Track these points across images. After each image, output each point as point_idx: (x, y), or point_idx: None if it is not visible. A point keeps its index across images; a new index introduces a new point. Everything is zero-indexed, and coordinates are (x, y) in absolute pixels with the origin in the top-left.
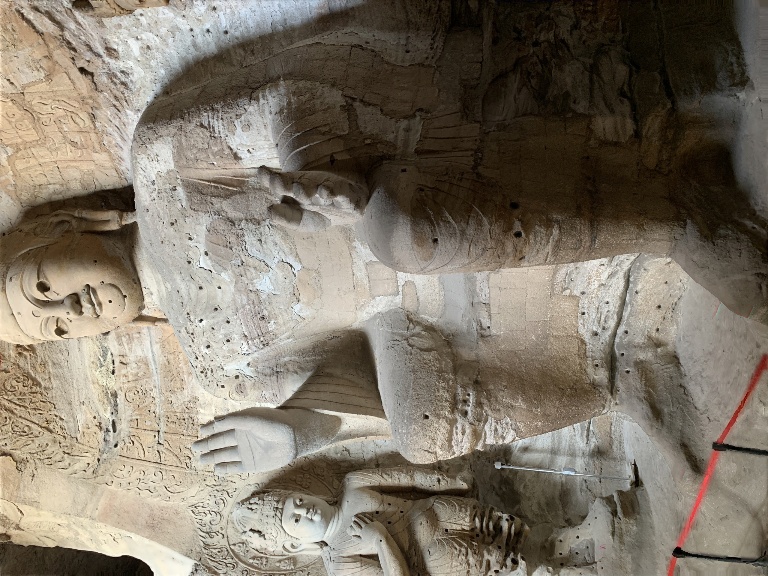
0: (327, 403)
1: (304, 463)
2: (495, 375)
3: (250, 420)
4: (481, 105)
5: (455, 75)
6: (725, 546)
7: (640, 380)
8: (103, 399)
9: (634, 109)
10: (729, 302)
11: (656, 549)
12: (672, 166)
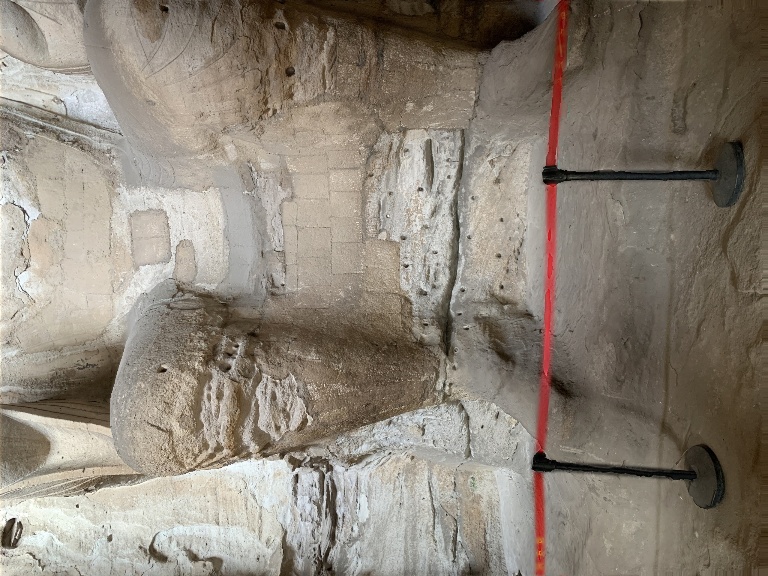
0: (30, 408)
1: None
2: (282, 329)
3: None
4: None
5: None
6: (636, 534)
7: (483, 332)
8: None
9: None
10: (543, 64)
11: None
12: (476, 38)
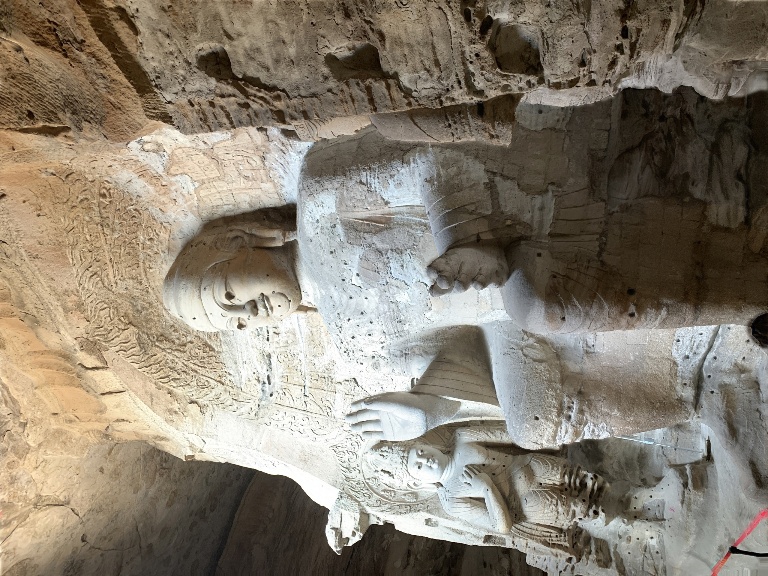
0: (451, 390)
1: None
2: (596, 387)
3: (392, 406)
4: (607, 181)
5: (584, 143)
6: None
7: (722, 401)
8: (260, 360)
9: (747, 195)
10: None
11: (718, 519)
12: None
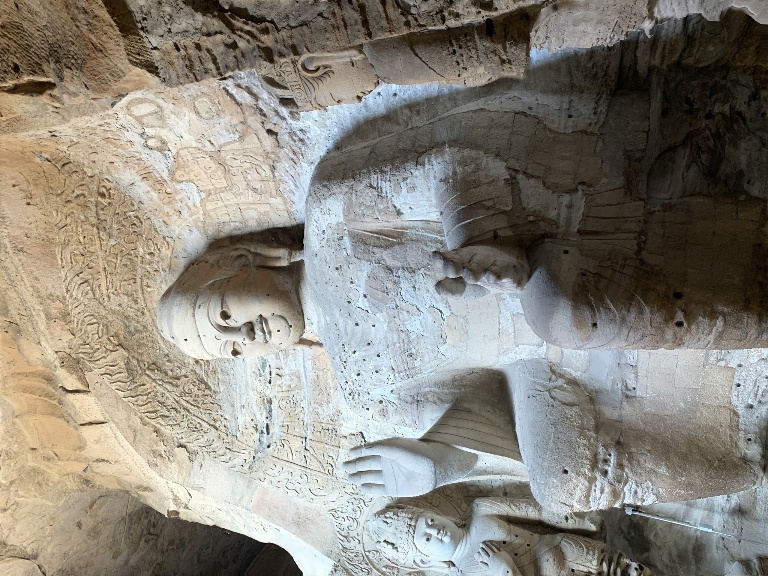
0: (466, 440)
1: None
2: (638, 438)
3: (396, 451)
4: (646, 181)
5: (619, 145)
6: None
7: None
8: (260, 405)
9: None
10: None
11: None
12: None
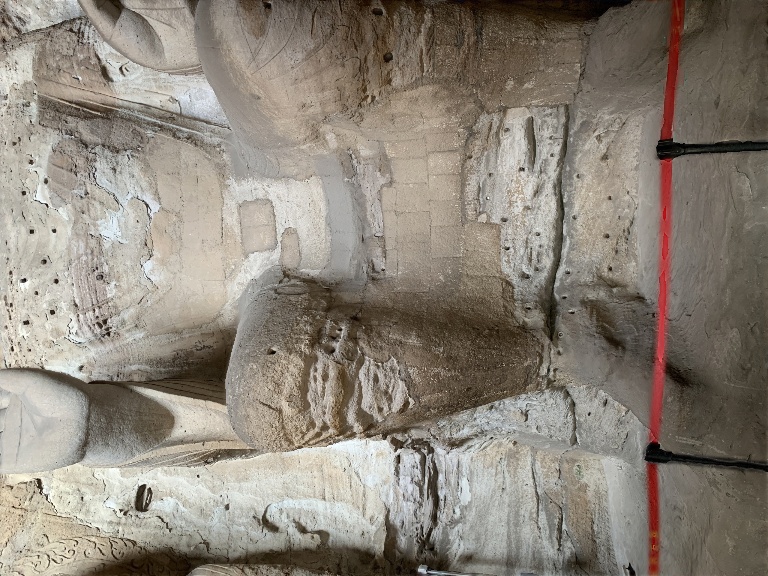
0: (156, 386)
1: (137, 556)
2: (383, 313)
3: (27, 375)
4: None
5: None
6: (764, 534)
7: (589, 316)
8: None
9: None
10: (657, 29)
11: None
12: (581, 7)
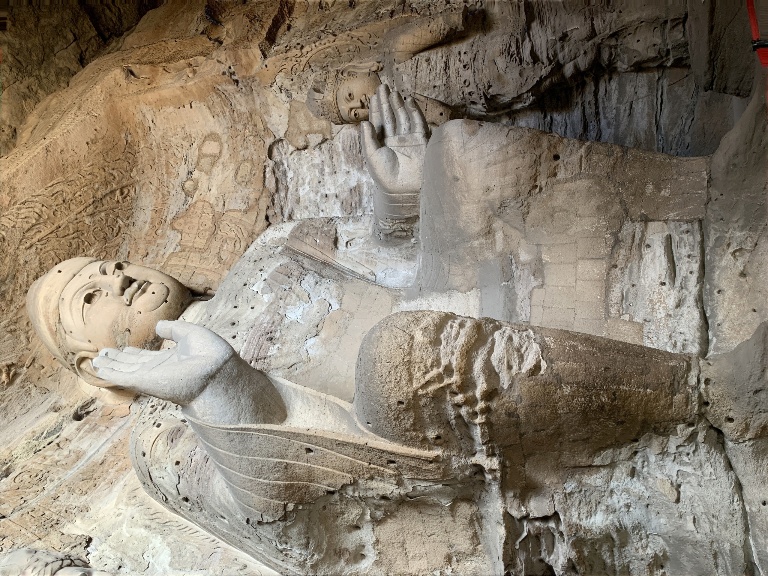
0: None
1: None
2: None
3: None
4: None
5: None
6: None
7: None
8: None
9: None
10: (756, 97)
11: None
12: None
